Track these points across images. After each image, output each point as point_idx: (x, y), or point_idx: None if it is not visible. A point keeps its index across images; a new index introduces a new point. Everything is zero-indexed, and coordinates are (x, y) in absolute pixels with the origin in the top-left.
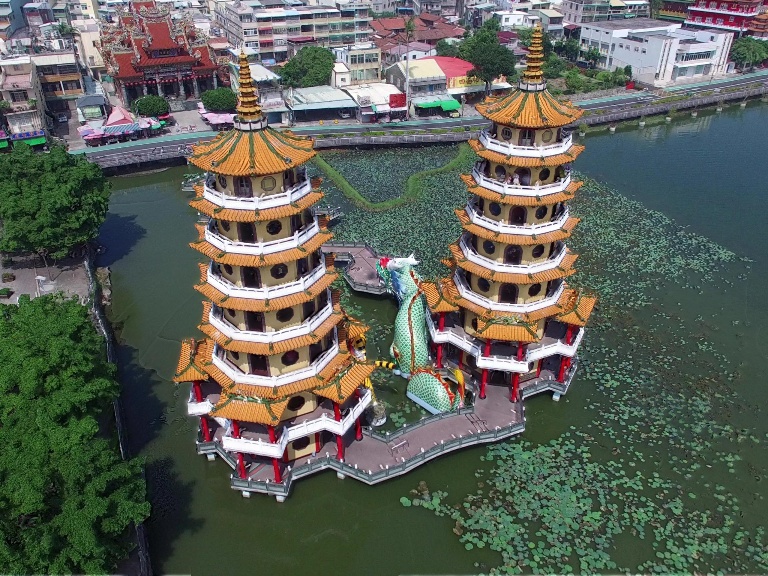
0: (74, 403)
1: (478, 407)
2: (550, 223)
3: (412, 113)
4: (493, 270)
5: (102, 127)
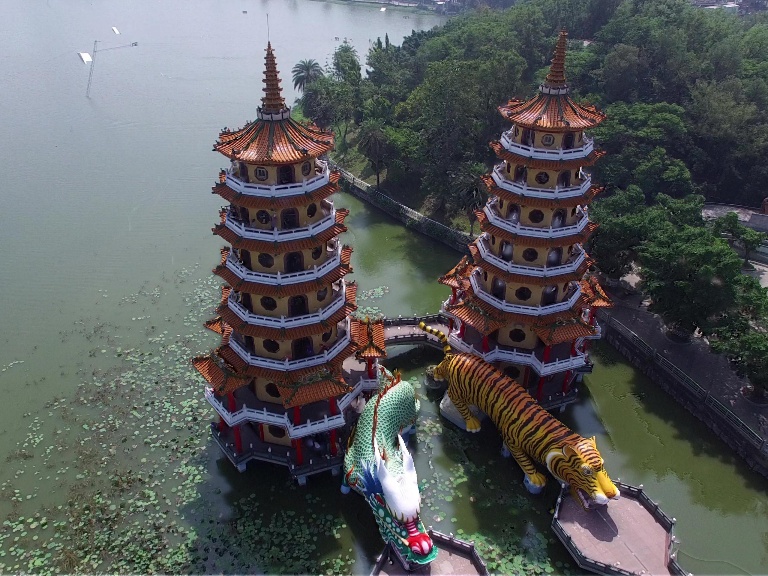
0: None
1: None
2: None
3: None
4: None
5: None
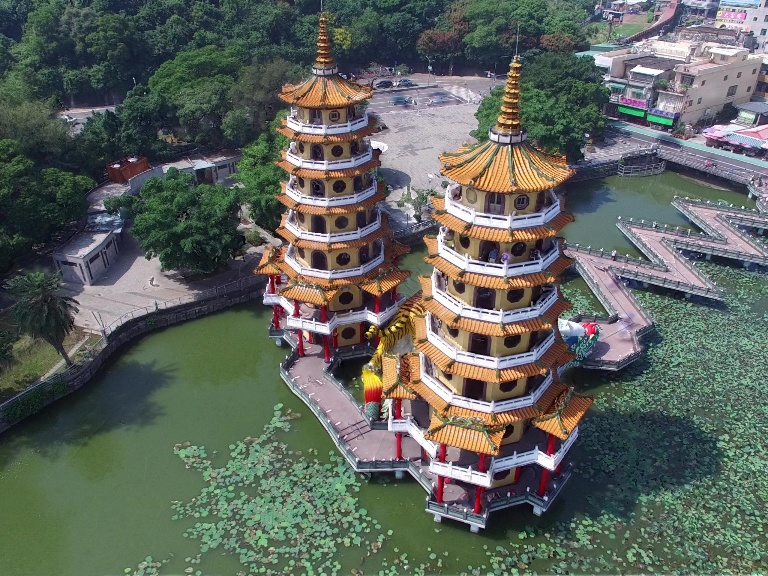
0: (261, 202)
1: (383, 433)
2: (452, 299)
3: None
4: None
5: (731, 132)
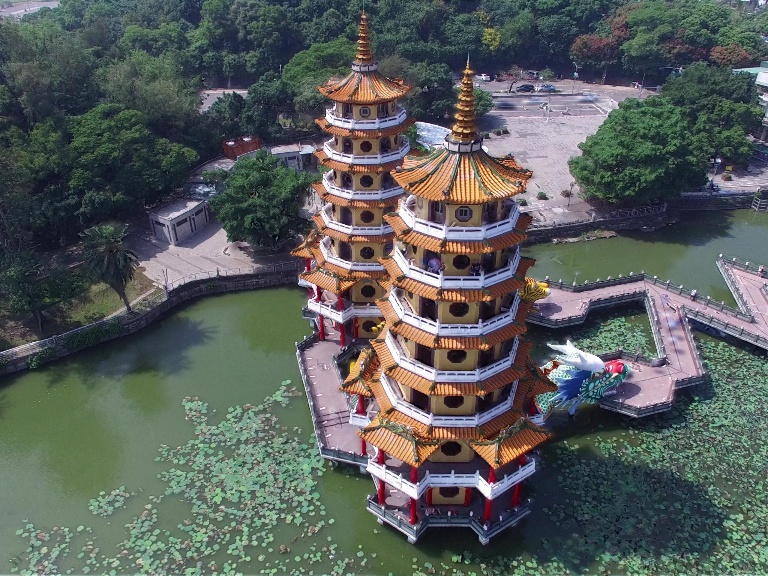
0: None
1: None
2: (400, 303)
3: None
4: None
5: None
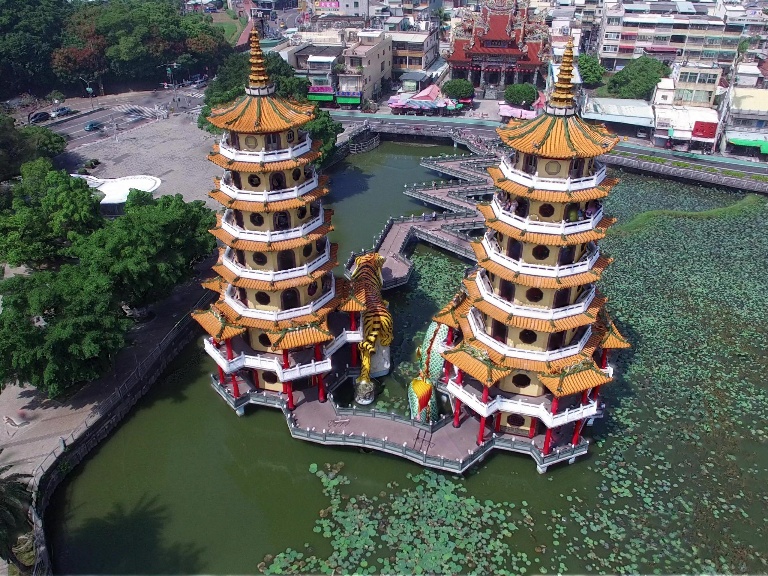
0: (129, 270)
1: (442, 431)
2: (544, 266)
3: (722, 148)
4: (482, 297)
5: (408, 99)
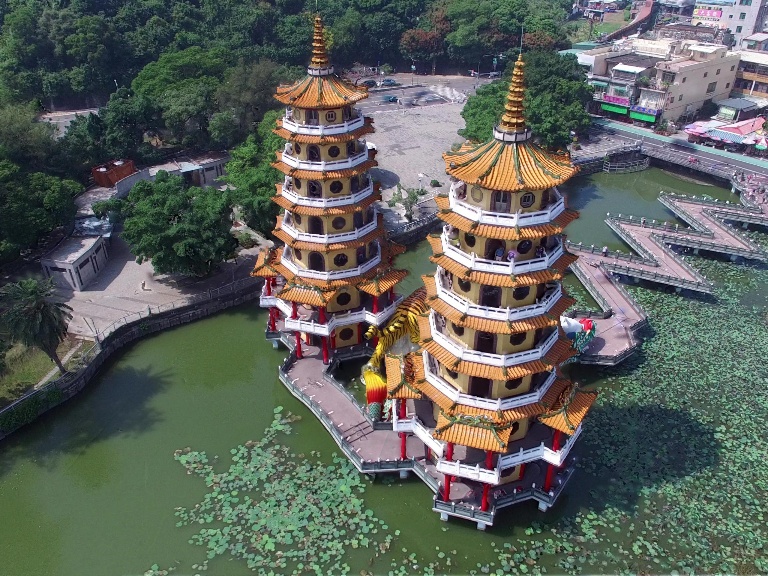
0: None
1: (386, 433)
2: (458, 298)
3: None
4: None
5: (712, 128)
